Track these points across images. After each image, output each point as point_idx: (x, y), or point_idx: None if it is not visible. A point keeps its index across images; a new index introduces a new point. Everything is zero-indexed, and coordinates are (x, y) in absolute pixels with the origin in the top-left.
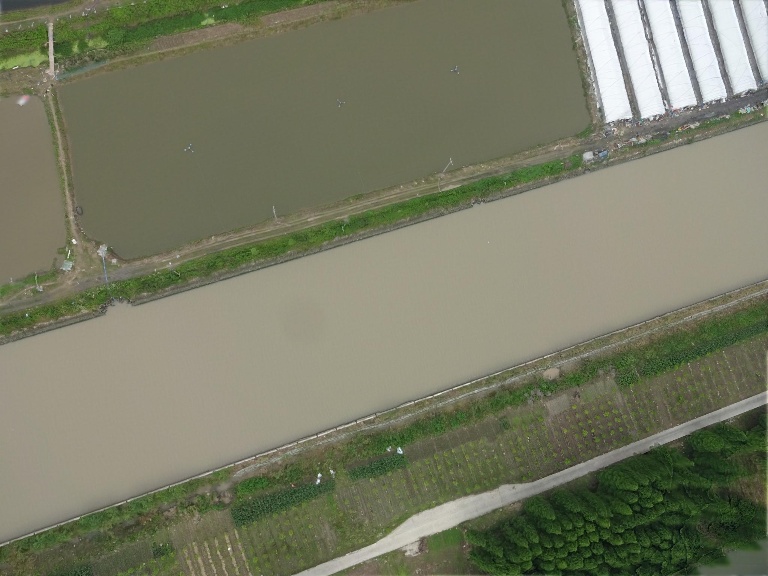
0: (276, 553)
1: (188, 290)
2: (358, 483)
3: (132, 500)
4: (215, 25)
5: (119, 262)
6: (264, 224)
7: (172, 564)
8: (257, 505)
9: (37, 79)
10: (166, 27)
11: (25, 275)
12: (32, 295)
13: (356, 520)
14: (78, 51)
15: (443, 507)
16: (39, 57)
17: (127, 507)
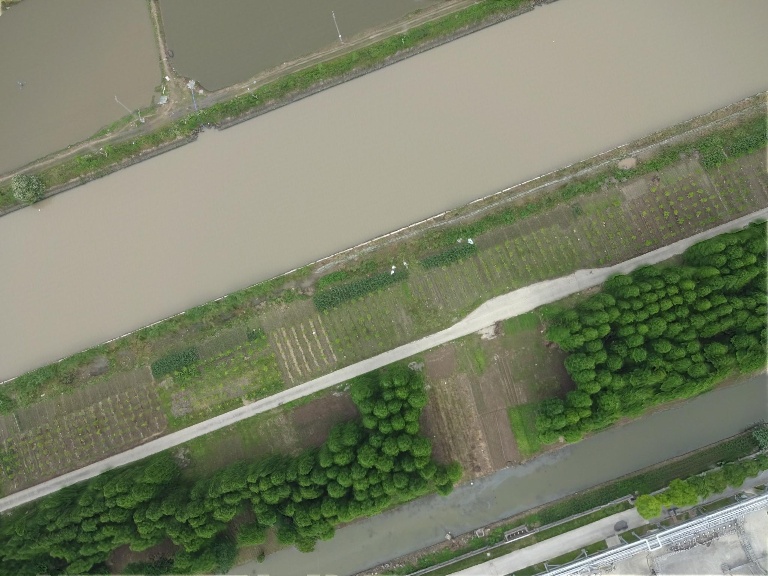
0: (357, 336)
1: (266, 113)
2: (431, 272)
3: (228, 295)
4: None
5: (205, 92)
6: (329, 46)
7: (264, 347)
8: (336, 292)
9: None
10: None
11: (130, 112)
12: (136, 126)
13: (431, 306)
14: None
15: (517, 292)
16: None
17: (224, 301)
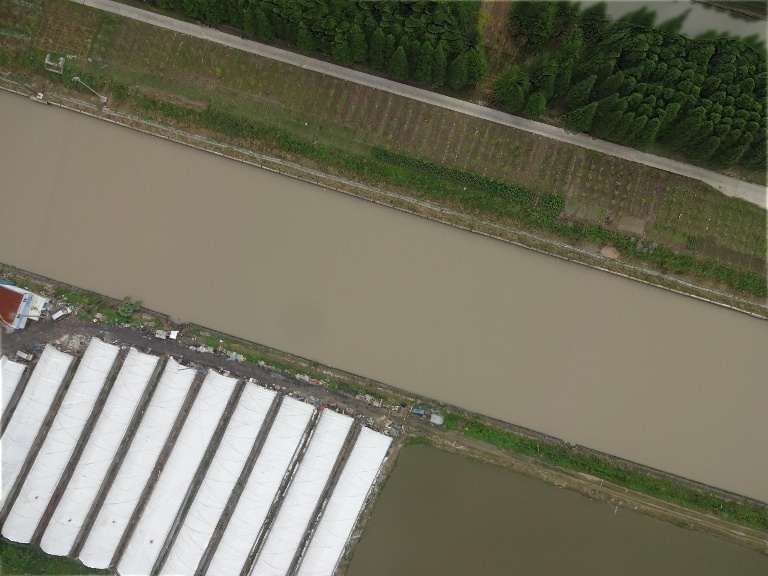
0: None
1: None
2: None
3: None
4: None
5: None
6: None
7: None
8: None
9: None
10: None
11: None
12: None
13: None
14: None
15: None
16: None
17: None
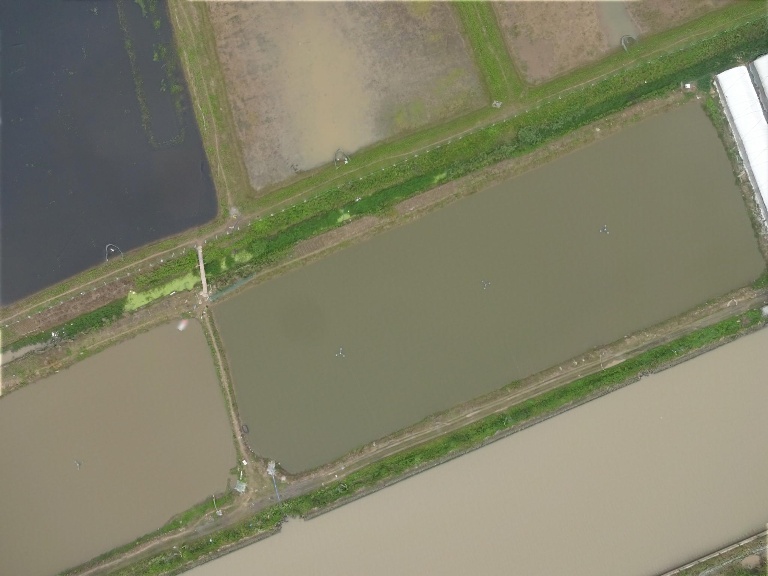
0: None
1: (355, 500)
2: None
3: None
4: (352, 221)
5: (288, 479)
6: (423, 425)
7: None
8: None
9: (193, 302)
10: (305, 230)
11: (204, 498)
12: (213, 520)
13: None
14: (226, 267)
15: None
16: (192, 279)
17: None
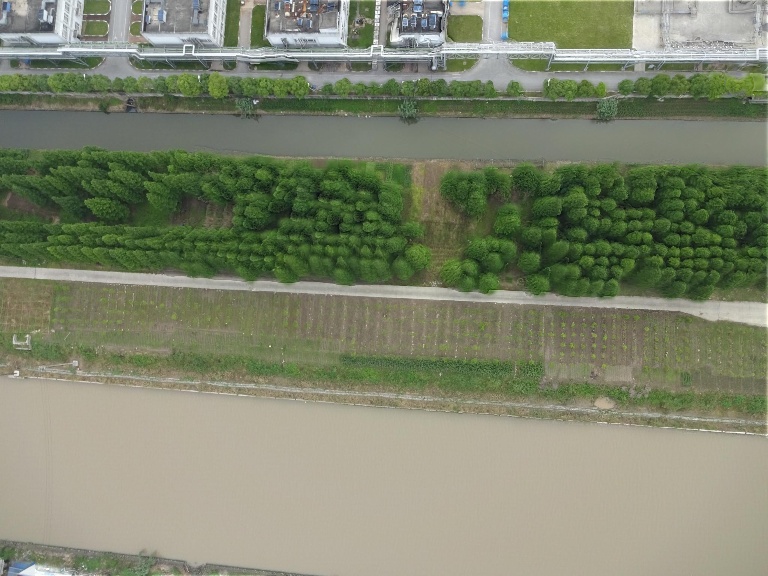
0: None
1: None
2: None
3: None
4: None
5: None
6: None
7: None
8: None
9: None
10: None
11: None
12: None
13: None
14: None
15: None
16: None
17: None
